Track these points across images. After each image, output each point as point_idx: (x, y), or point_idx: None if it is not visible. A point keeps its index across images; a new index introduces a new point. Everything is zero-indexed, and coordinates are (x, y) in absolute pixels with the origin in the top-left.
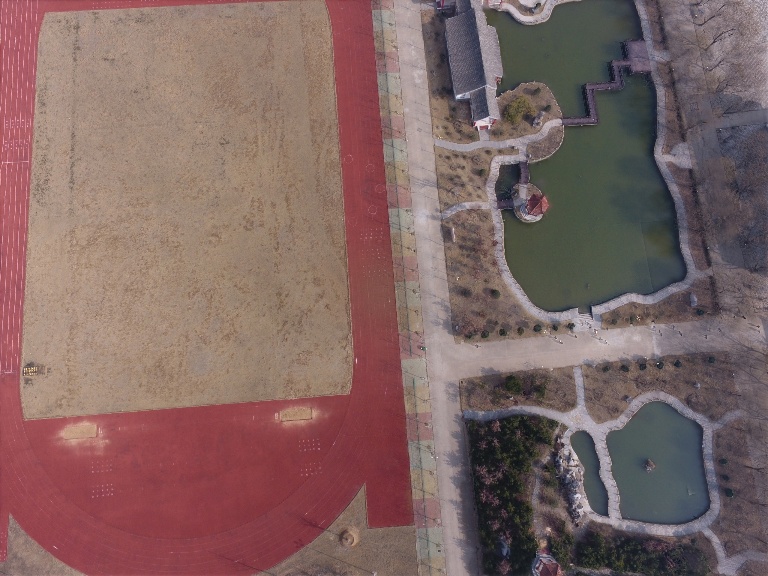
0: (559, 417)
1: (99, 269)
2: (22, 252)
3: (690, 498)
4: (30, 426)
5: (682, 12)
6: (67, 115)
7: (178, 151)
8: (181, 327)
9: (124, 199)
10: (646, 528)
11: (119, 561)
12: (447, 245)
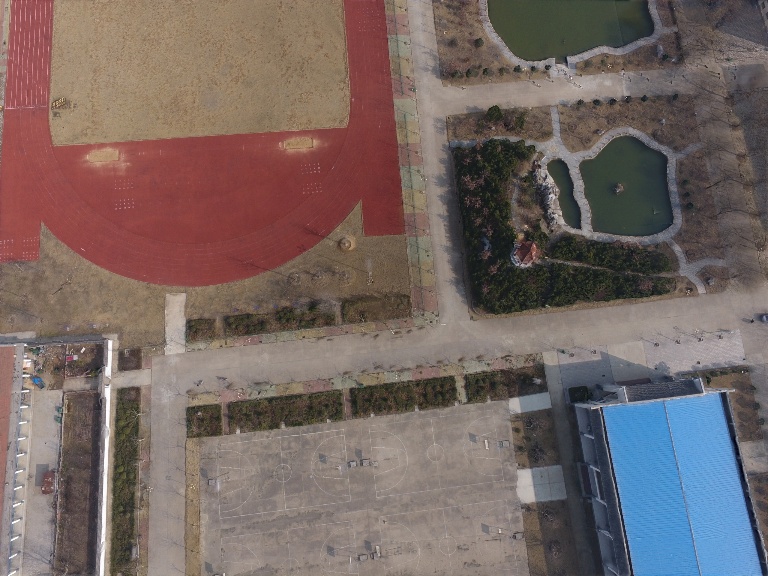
0: (537, 146)
1: (119, 22)
2: (49, 8)
3: (655, 216)
4: (59, 151)
5: None
6: None
7: None
8: (194, 71)
9: None
10: (615, 239)
11: (140, 261)
12: (435, 5)
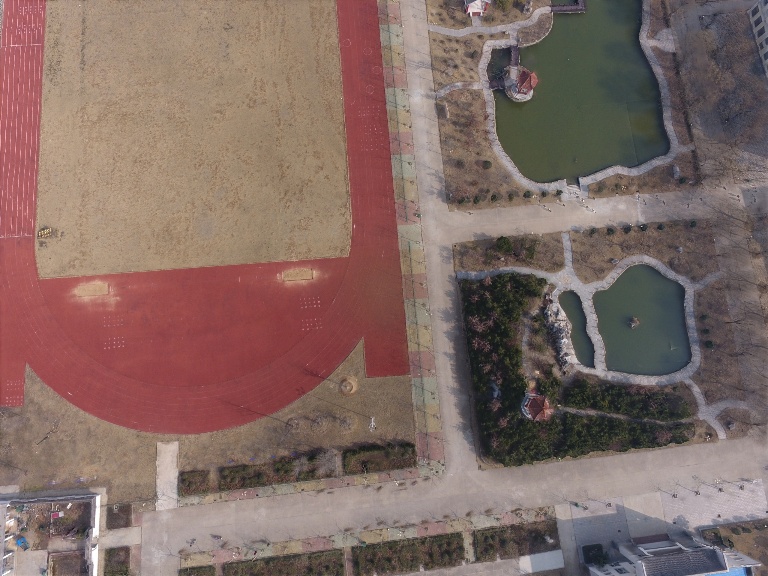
0: (548, 277)
1: (109, 142)
2: (36, 126)
3: (672, 352)
4: (45, 284)
5: None
6: (78, 2)
7: (184, 35)
8: (188, 195)
9: (133, 79)
10: (630, 378)
11: (130, 406)
12: (441, 121)
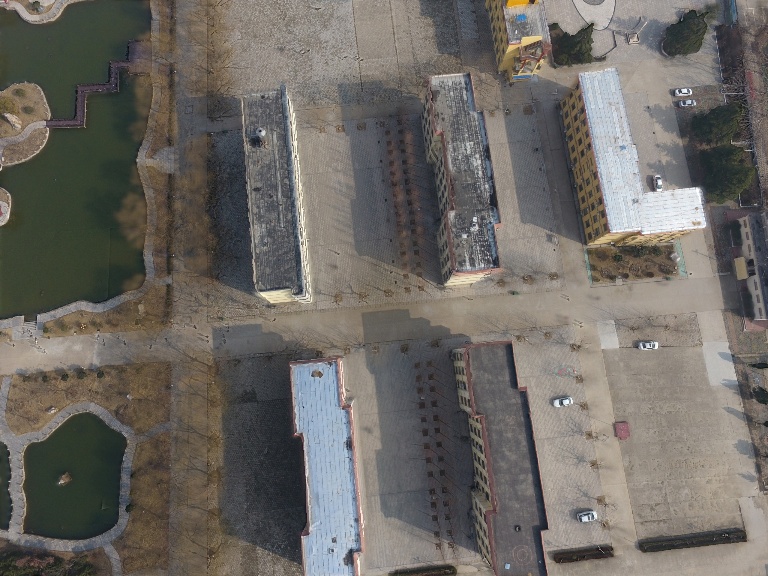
0: None
1: None
2: None
3: None
4: None
5: (197, 12)
6: None
7: None
8: None
9: None
10: (45, 543)
11: None
12: None
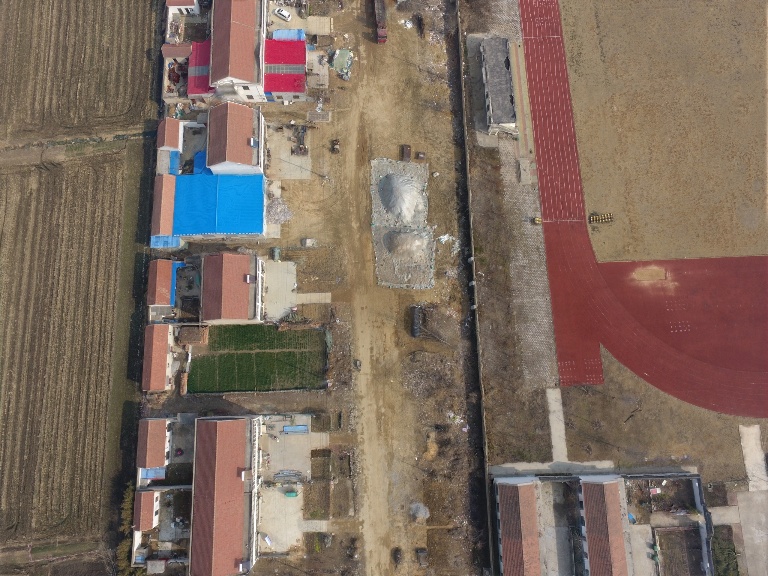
0: None
1: (642, 132)
2: (570, 115)
3: None
4: (604, 268)
5: None
6: None
7: (695, 31)
8: (726, 186)
9: (654, 72)
10: None
11: (706, 388)
12: None
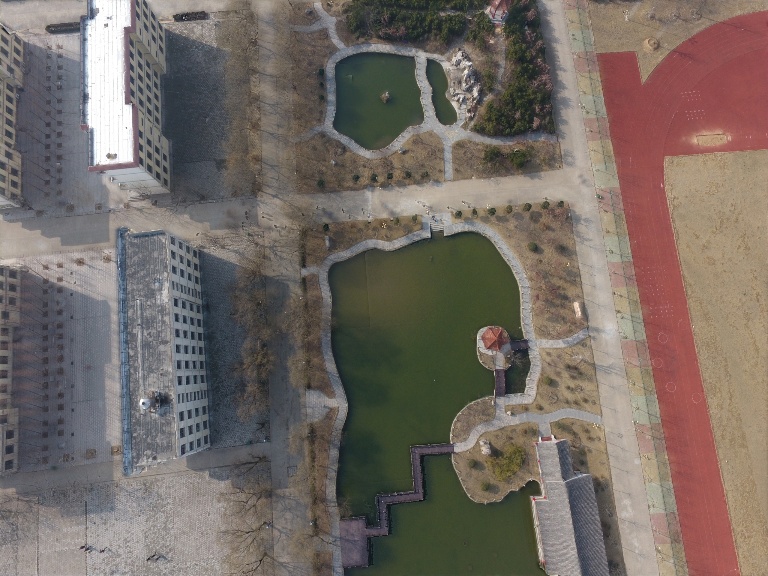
0: (469, 136)
1: None
2: None
3: None
4: None
5: None
6: None
7: None
8: None
9: None
10: (394, 50)
11: None
12: (581, 300)
